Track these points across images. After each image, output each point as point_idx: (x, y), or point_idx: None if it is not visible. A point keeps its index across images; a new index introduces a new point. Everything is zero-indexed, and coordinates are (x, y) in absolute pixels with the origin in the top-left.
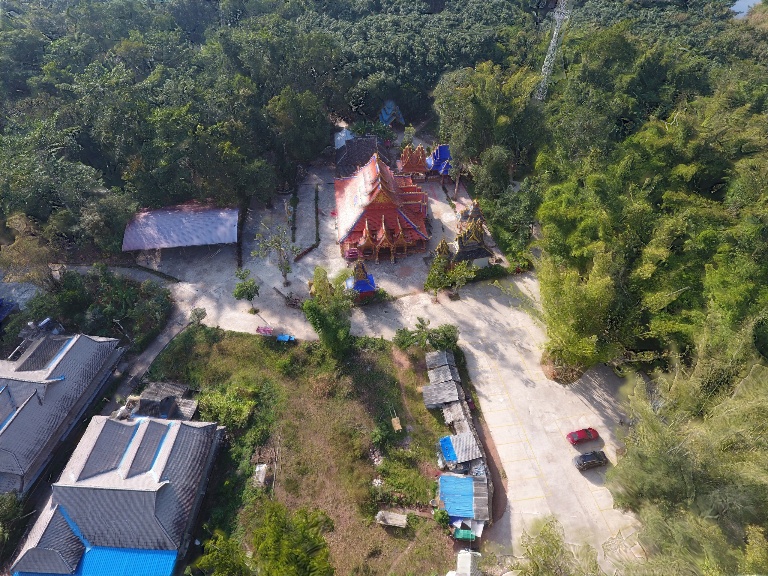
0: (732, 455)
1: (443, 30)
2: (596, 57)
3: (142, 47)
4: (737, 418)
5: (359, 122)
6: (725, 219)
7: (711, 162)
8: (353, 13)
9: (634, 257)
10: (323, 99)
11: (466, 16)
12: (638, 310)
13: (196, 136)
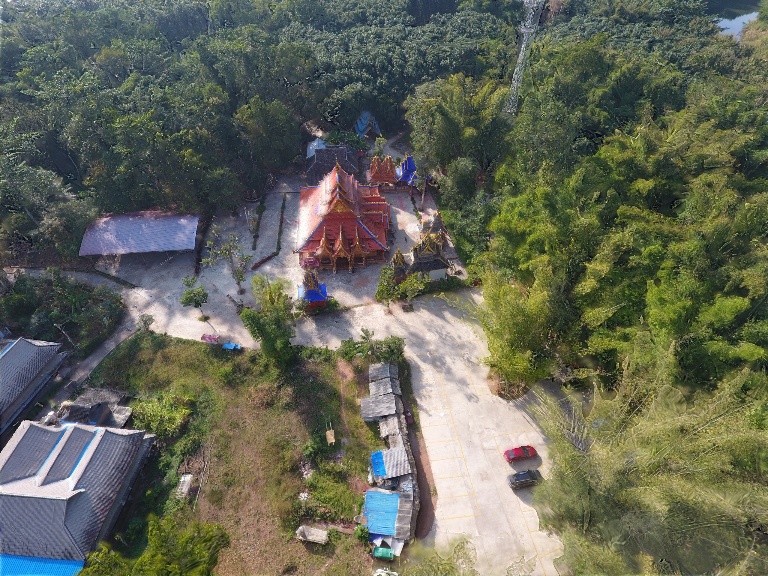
0: (637, 479)
1: (424, 42)
2: (571, 71)
3: (123, 55)
4: (643, 440)
5: (332, 132)
6: (675, 235)
7: (671, 177)
8: (338, 25)
9: (579, 272)
10: (293, 108)
11: (450, 29)
12: (577, 326)
13: (156, 143)
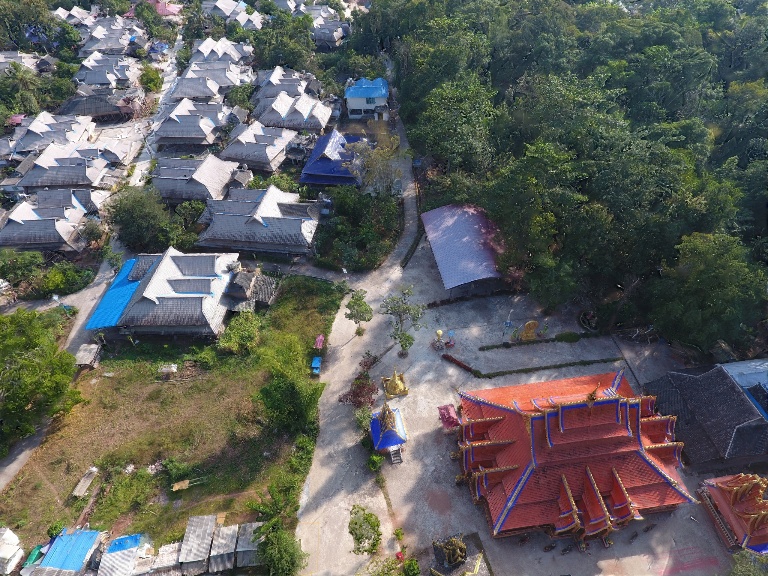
0: None
1: None
2: None
3: (765, 98)
4: None
5: None
6: None
7: None
8: None
9: None
10: None
11: None
12: None
13: None
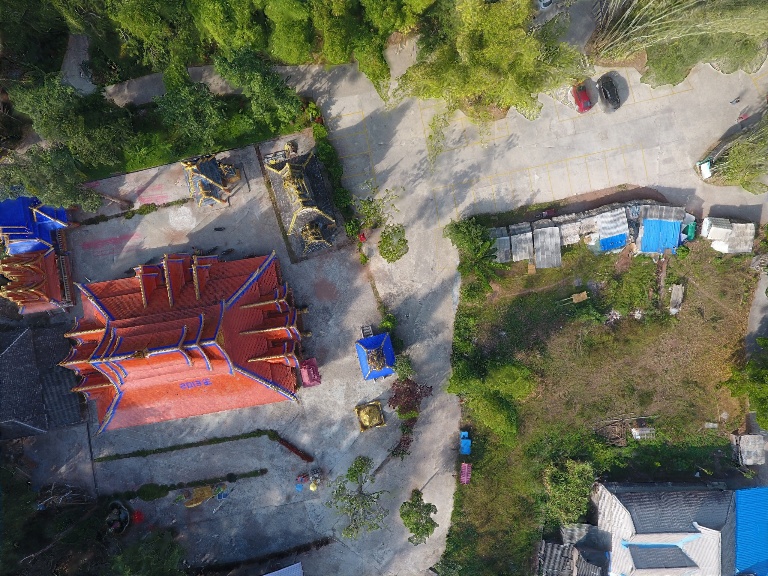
0: None
1: None
2: None
3: None
4: None
5: None
6: None
7: None
8: None
9: None
10: None
11: None
12: None
13: None
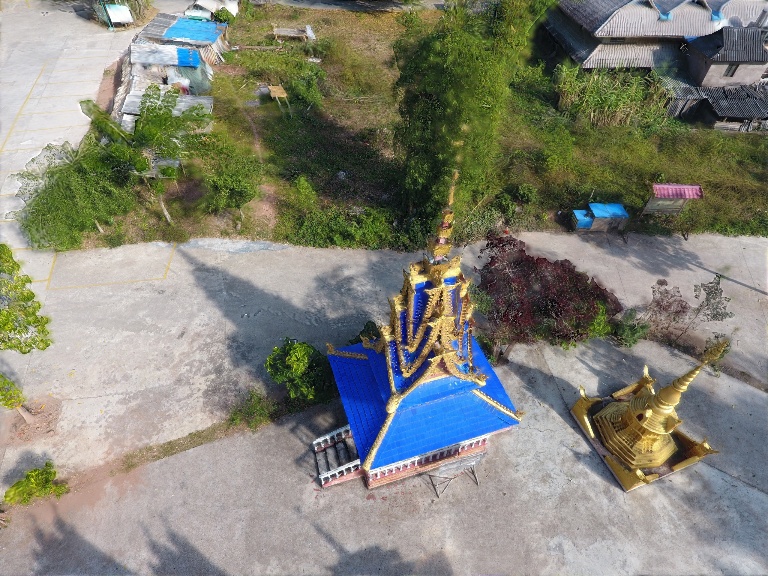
0: None
1: None
2: None
3: None
4: None
5: None
6: None
7: None
8: None
9: None
10: None
11: None
12: None
13: None
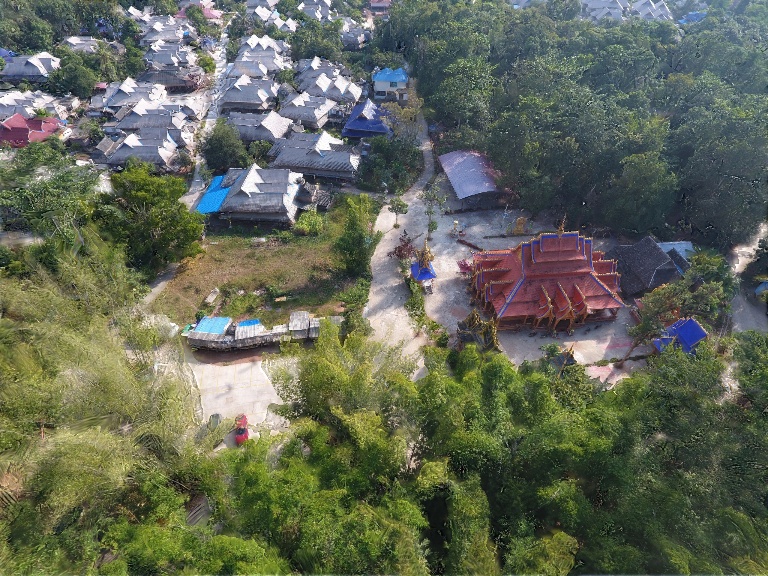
0: None
1: None
2: None
3: None
4: None
5: (714, 250)
6: None
7: None
8: None
9: (391, 431)
10: None
11: None
12: None
13: None
